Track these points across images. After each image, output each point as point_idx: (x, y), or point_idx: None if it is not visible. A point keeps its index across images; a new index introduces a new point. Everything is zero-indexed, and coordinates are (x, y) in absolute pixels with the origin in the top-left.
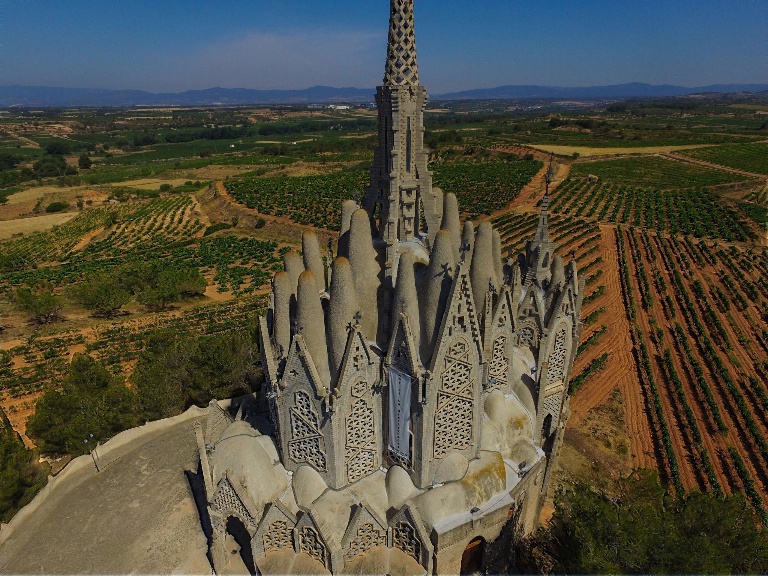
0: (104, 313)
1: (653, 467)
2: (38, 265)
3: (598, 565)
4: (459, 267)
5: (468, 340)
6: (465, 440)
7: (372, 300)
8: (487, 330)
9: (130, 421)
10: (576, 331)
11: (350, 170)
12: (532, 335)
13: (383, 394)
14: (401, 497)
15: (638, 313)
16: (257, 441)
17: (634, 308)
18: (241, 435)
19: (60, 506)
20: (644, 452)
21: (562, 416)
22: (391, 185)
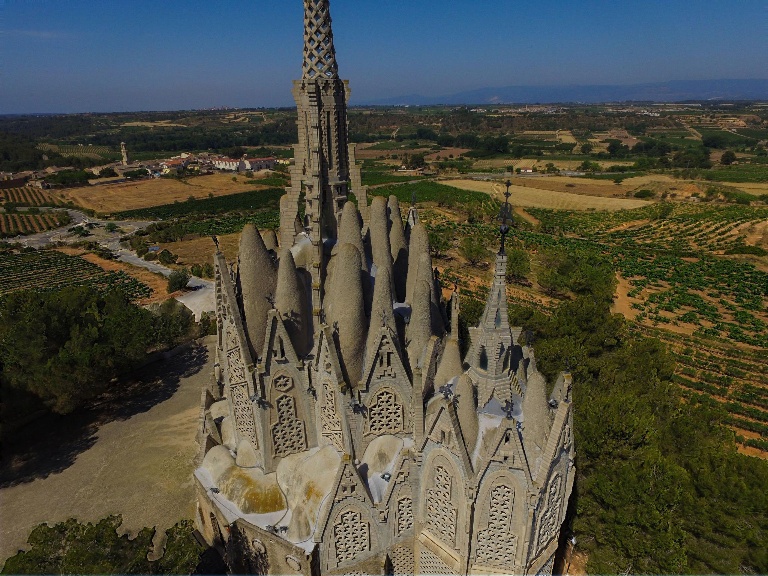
0: (516, 277)
1: None
2: (567, 234)
3: (60, 525)
4: None
5: None
6: None
7: None
8: None
9: None
10: (468, 494)
11: None
12: None
13: None
14: (231, 440)
15: None
16: None
17: None
18: None
19: None
20: None
21: None
22: None
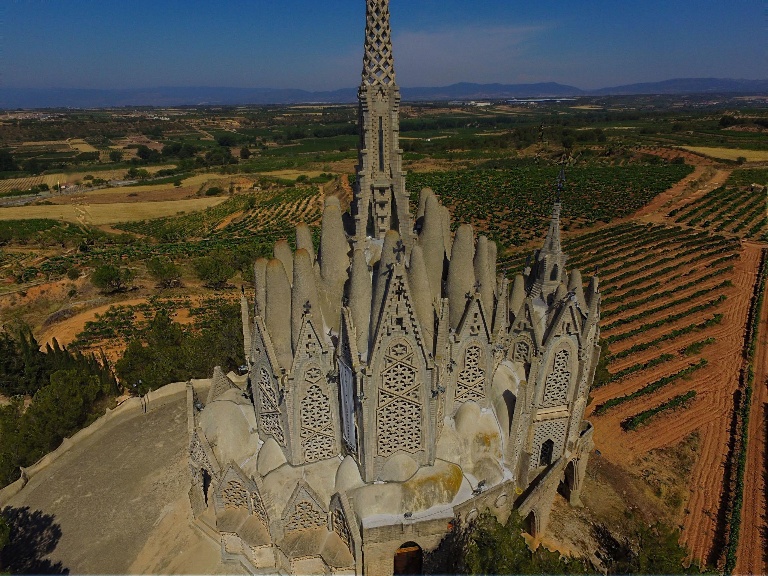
0: None
1: (709, 530)
2: (187, 239)
3: None
4: (393, 268)
5: (411, 343)
6: (415, 444)
7: (339, 293)
8: (440, 336)
9: (182, 376)
10: (582, 354)
11: (470, 168)
12: (527, 351)
13: (338, 384)
14: (345, 486)
15: (761, 351)
16: (239, 408)
17: (755, 344)
18: (227, 400)
19: (109, 434)
20: (704, 511)
21: (571, 445)
22: (360, 183)
